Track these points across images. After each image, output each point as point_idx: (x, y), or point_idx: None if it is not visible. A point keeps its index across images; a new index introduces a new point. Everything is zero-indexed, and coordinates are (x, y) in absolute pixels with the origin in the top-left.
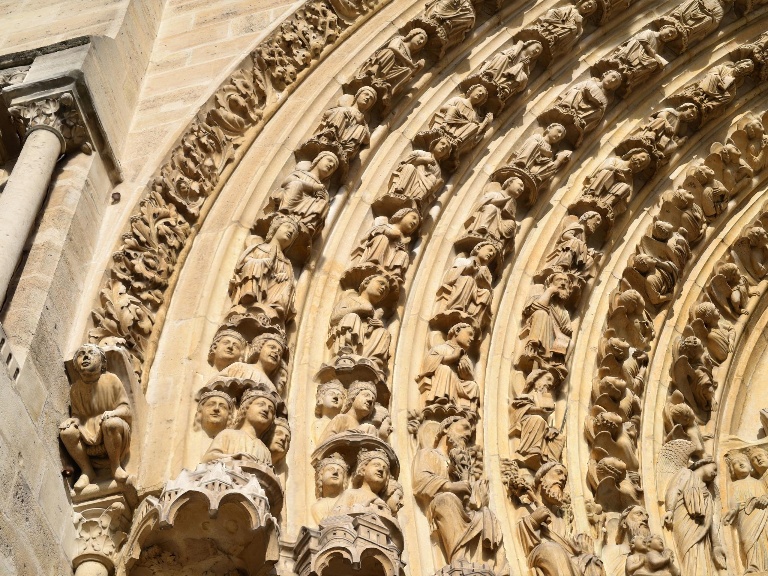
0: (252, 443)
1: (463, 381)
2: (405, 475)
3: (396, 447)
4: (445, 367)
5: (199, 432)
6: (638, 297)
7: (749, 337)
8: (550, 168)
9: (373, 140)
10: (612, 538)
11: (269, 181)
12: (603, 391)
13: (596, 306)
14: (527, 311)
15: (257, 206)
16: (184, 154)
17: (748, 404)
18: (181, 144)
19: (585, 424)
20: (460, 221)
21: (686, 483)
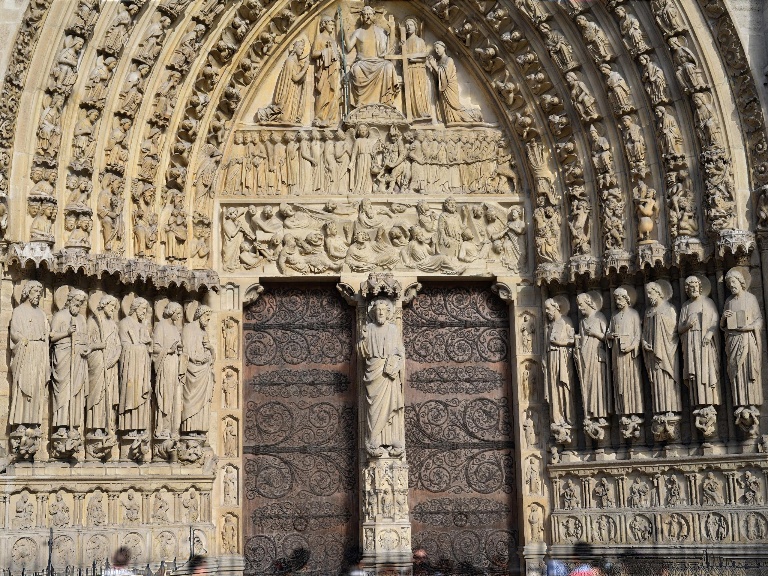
0: (46, 224)
1: (123, 151)
2: (95, 204)
3: (93, 188)
4: (117, 148)
5: (29, 216)
6: (212, 73)
7: (268, 62)
8: (186, 5)
9: (102, 6)
10: (169, 201)
11: (53, 55)
12: (183, 127)
13: (193, 72)
14: (158, 94)
15: (48, 74)
16: (18, 51)
17: (256, 98)
18: (16, 43)
19: (171, 148)
20: (137, 42)
21: (207, 166)
